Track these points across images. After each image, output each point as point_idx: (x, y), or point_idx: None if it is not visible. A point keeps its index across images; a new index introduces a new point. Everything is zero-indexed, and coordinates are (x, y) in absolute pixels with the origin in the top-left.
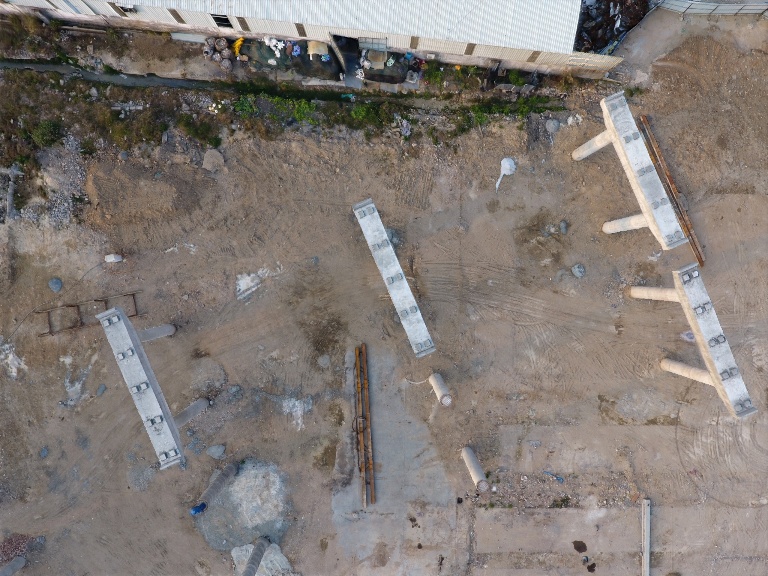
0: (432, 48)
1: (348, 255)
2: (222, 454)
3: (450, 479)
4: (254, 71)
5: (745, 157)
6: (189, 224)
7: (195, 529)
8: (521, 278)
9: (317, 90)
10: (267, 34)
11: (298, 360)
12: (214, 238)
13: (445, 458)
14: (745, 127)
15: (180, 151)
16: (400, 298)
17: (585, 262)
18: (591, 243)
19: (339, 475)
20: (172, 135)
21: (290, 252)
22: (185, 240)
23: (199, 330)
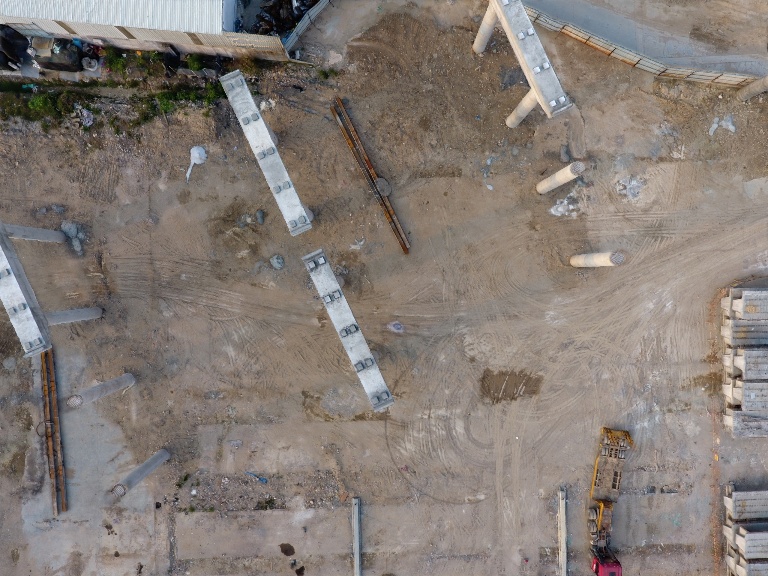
0: (91, 33)
1: (31, 252)
2: None
3: (147, 483)
4: None
5: (449, 138)
6: None
7: None
8: (216, 271)
9: None
10: None
11: None
12: None
13: (141, 461)
14: (448, 107)
15: None
16: (8, 295)
17: (284, 253)
18: None
19: (29, 482)
20: None
21: None
22: None
23: None
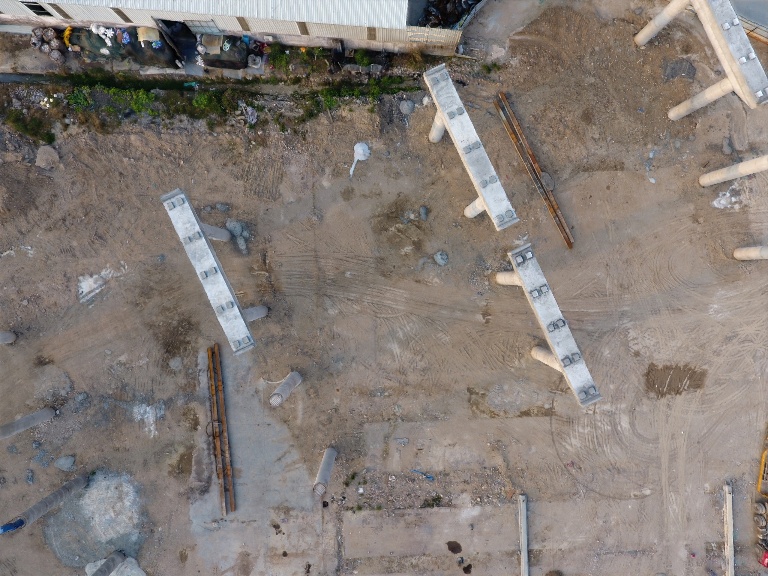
0: (266, 29)
1: None
2: (71, 466)
3: (314, 482)
4: (88, 62)
5: (612, 132)
6: (25, 225)
7: (46, 546)
8: (381, 268)
9: (157, 79)
10: (92, 21)
11: (148, 364)
12: (52, 239)
13: (308, 460)
14: (610, 100)
15: (11, 149)
16: (215, 293)
17: (448, 249)
18: (453, 228)
19: (196, 483)
20: (1, 132)
21: (134, 250)
22: (22, 242)
23: (41, 336)
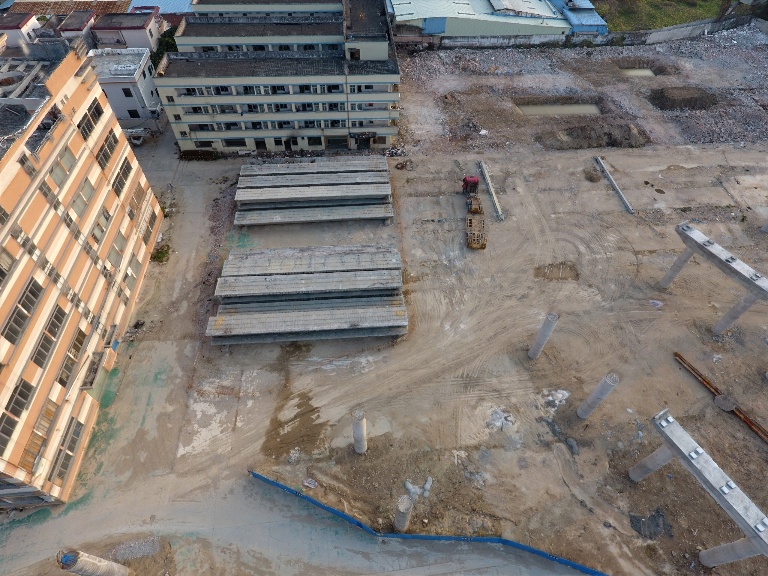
0: None
1: None
2: None
3: (764, 218)
4: None
5: None
6: None
7: None
8: None
9: None
10: None
11: None
12: None
13: None
14: None
15: None
16: None
17: None
18: None
19: None
20: None
21: None
22: None
23: None
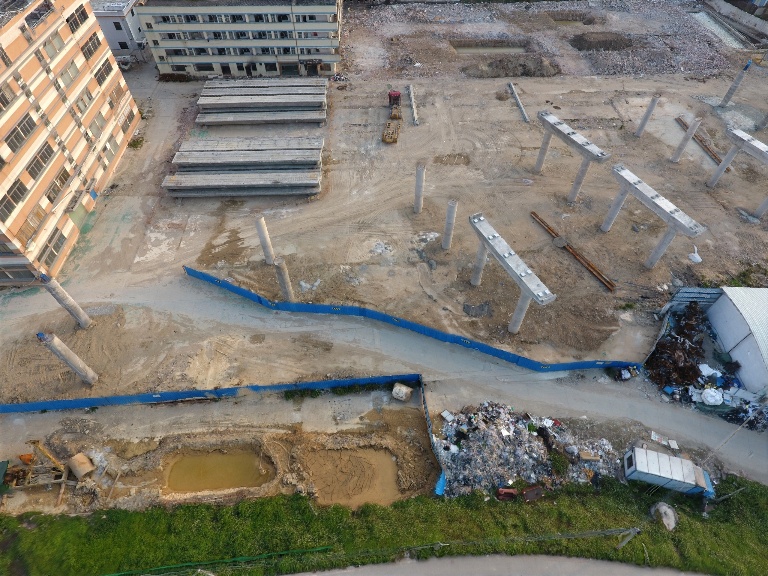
0: None
1: None
2: None
3: None
4: None
5: None
6: None
7: (760, 110)
8: None
9: None
10: None
11: (760, 165)
12: None
13: None
14: None
15: None
16: (761, 144)
17: None
18: None
19: (701, 127)
20: None
21: None
22: None
23: None
